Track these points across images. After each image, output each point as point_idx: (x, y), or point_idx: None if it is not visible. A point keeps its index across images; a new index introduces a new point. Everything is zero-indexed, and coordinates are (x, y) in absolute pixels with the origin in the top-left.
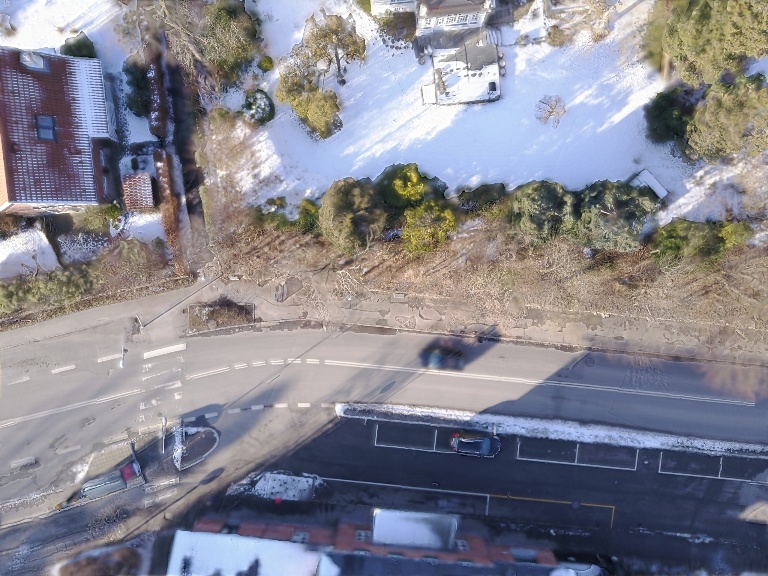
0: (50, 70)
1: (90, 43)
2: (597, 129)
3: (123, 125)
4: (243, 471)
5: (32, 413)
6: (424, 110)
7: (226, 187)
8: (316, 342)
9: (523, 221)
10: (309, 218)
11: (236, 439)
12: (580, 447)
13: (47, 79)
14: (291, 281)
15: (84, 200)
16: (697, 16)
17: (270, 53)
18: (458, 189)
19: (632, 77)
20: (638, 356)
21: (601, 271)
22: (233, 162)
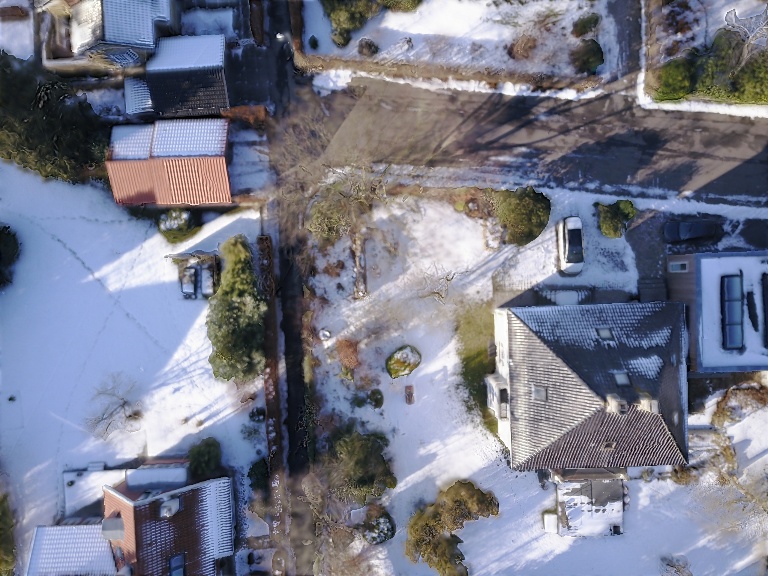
0: (185, 506)
1: (218, 448)
2: (718, 575)
3: (242, 518)
4: None
5: None
6: (543, 534)
7: None
8: None
9: None
10: None
11: None
12: None
13: (182, 518)
14: None
15: None
16: None
17: (394, 467)
18: None
19: (758, 526)
20: None
21: None
22: (350, 571)
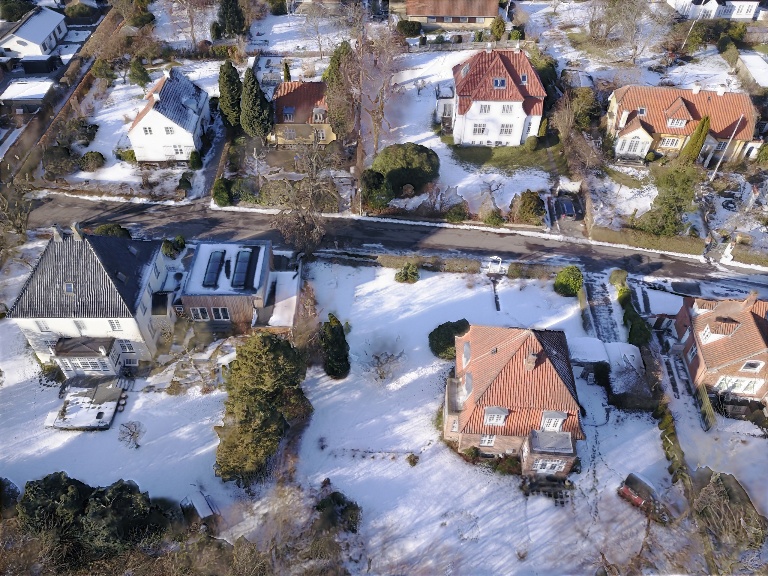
0: None
1: None
2: (179, 458)
3: None
4: None
5: None
6: (45, 432)
7: None
8: None
9: None
10: None
11: None
12: None
13: None
14: None
15: None
16: None
17: None
18: None
19: None
20: None
21: None
22: None
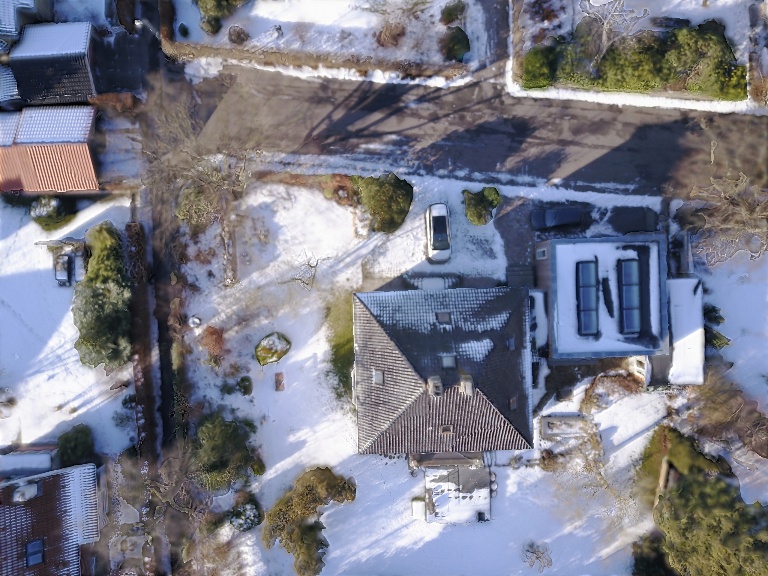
0: (44, 492)
1: (88, 435)
2: (584, 562)
3: (115, 505)
4: None
5: None
6: (413, 521)
7: None
8: None
9: None
10: None
11: None
12: None
13: (40, 503)
14: None
15: None
16: (688, 524)
17: (264, 454)
18: None
19: (624, 512)
20: None
21: None
22: (220, 558)
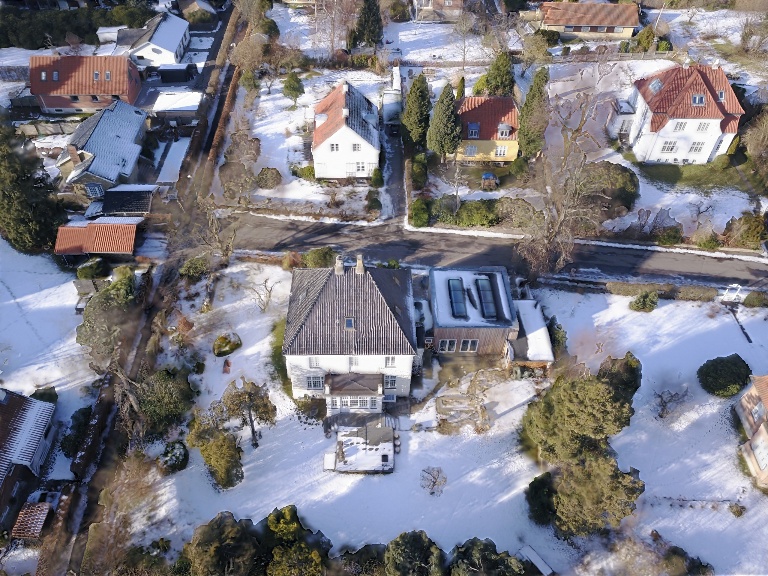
0: (8, 404)
1: (55, 396)
2: (482, 506)
3: (50, 463)
4: None
5: None
6: (324, 476)
7: (118, 527)
8: None
9: (387, 567)
10: (185, 562)
11: None
12: None
13: (1, 409)
14: None
15: None
16: (546, 407)
17: None
18: None
19: (512, 464)
20: None
21: None
22: (134, 504)
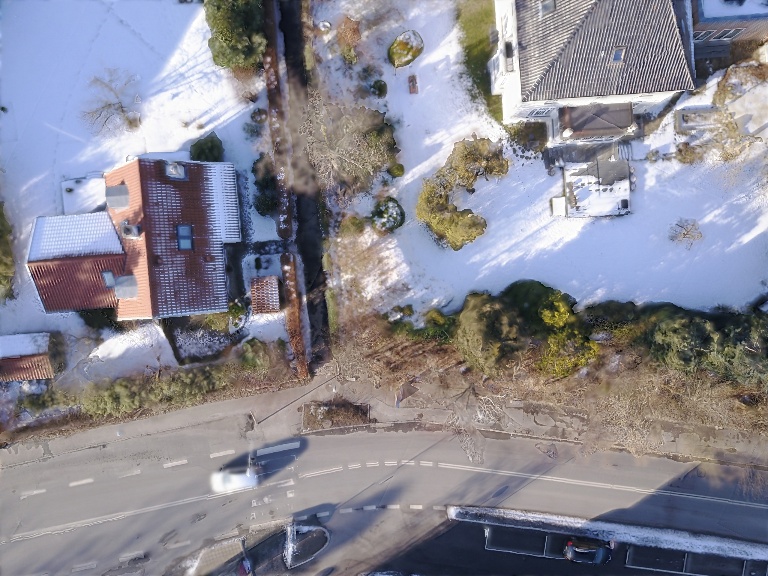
0: (190, 178)
1: (220, 143)
2: (725, 248)
3: (247, 224)
4: (352, 571)
5: (142, 507)
6: (552, 221)
7: (350, 291)
8: (430, 444)
9: (670, 357)
10: (438, 330)
11: (347, 539)
12: (688, 556)
13: (187, 188)
14: (408, 384)
15: (217, 308)
16: None
17: (400, 159)
18: (582, 301)
19: (762, 198)
20: (749, 468)
21: (721, 387)
22: (359, 267)
